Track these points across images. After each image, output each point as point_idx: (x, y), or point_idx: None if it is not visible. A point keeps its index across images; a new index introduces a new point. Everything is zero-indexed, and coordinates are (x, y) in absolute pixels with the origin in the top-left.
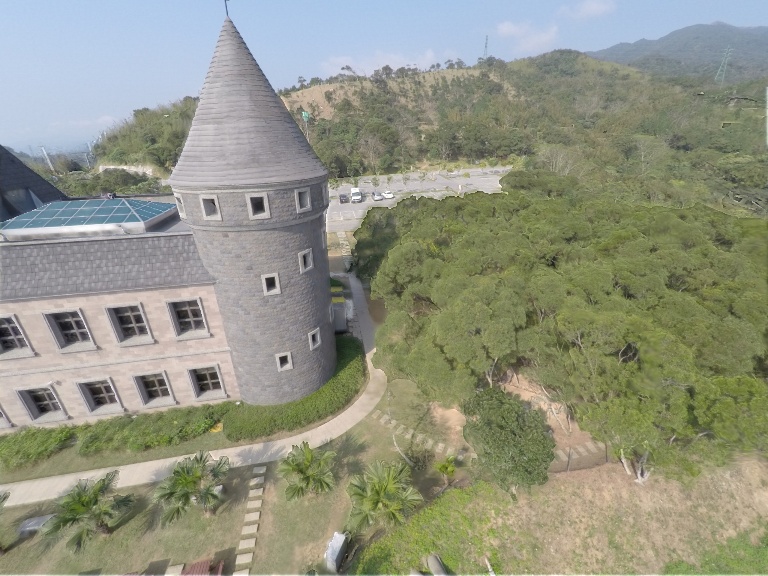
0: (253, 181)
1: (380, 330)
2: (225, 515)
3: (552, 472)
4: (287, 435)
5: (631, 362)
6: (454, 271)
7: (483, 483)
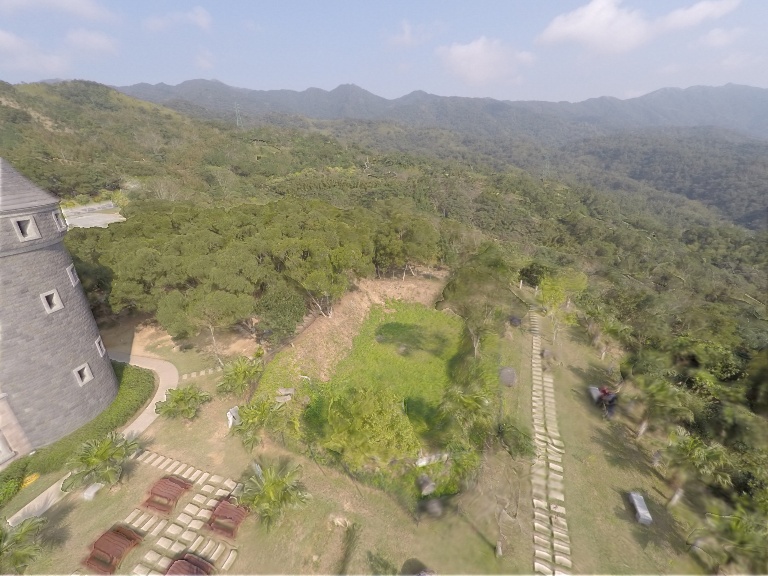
0: (18, 206)
1: (162, 312)
2: (133, 479)
3: (301, 333)
4: (124, 428)
5: (308, 257)
6: (191, 257)
7: (278, 353)
